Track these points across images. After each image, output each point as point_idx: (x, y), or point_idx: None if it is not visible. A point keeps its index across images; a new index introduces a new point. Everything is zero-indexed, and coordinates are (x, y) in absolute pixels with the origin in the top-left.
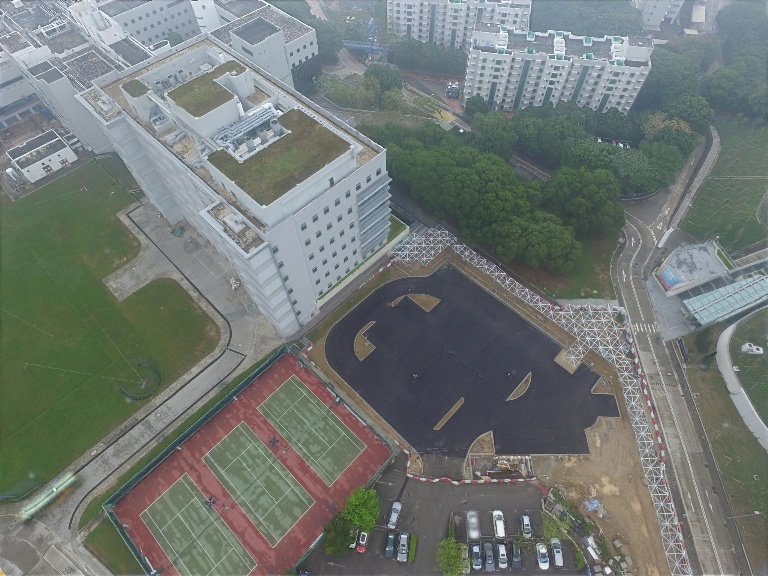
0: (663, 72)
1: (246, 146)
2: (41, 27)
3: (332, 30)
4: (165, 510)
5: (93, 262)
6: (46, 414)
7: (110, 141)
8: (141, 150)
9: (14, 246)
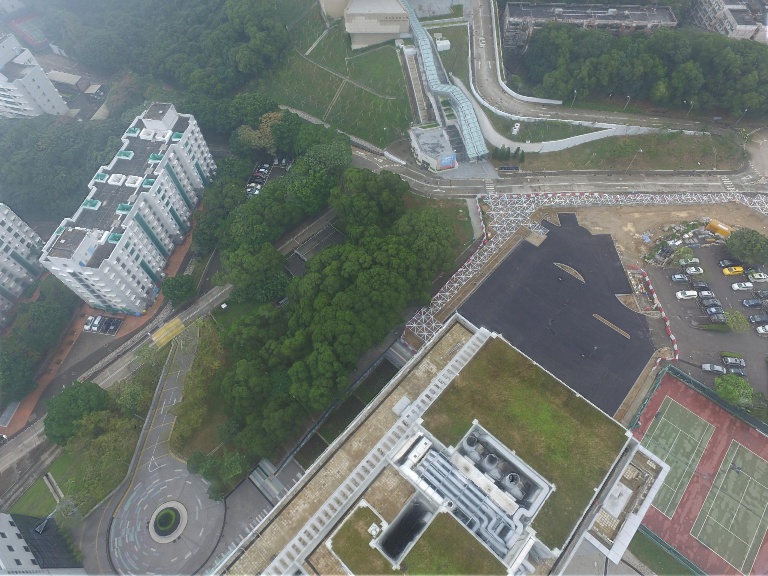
0: None
1: None
2: None
3: None
4: None
5: None
6: None
7: None
8: None
9: None
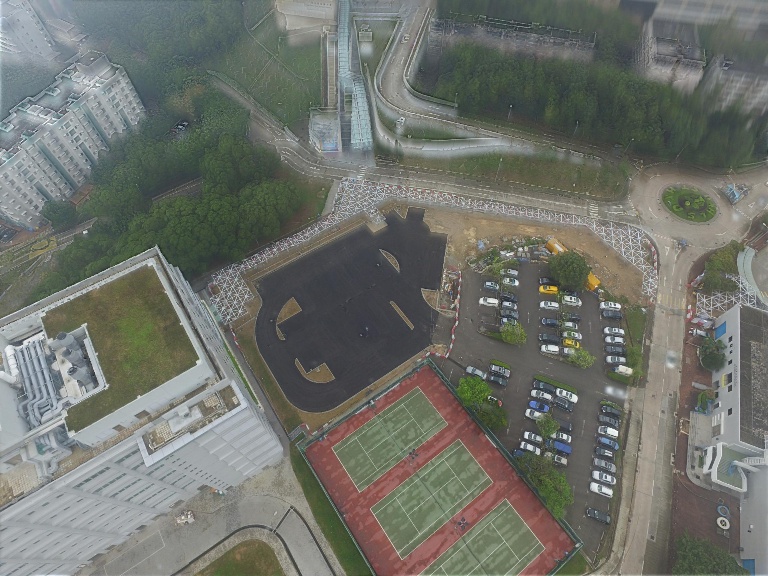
0: None
1: (79, 379)
2: None
3: None
4: None
5: None
6: None
7: None
8: None
9: None
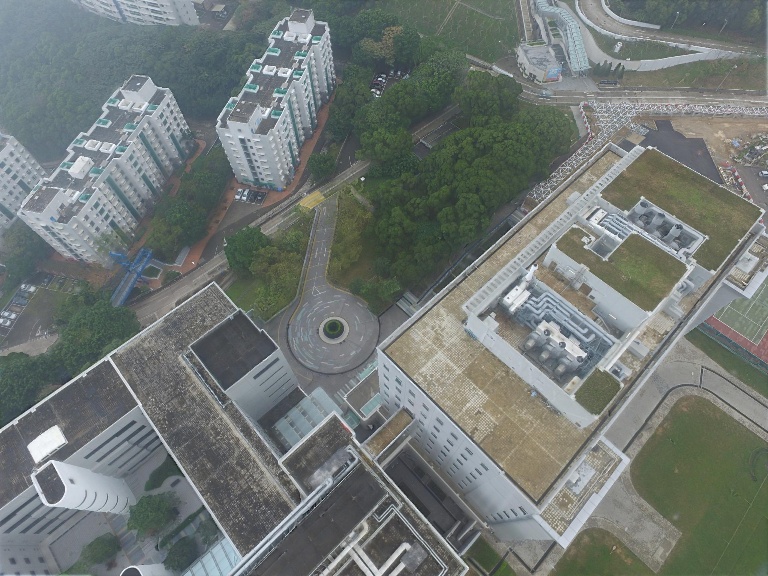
0: None
1: None
2: None
3: (104, 311)
4: None
5: None
6: None
7: None
8: None
9: None
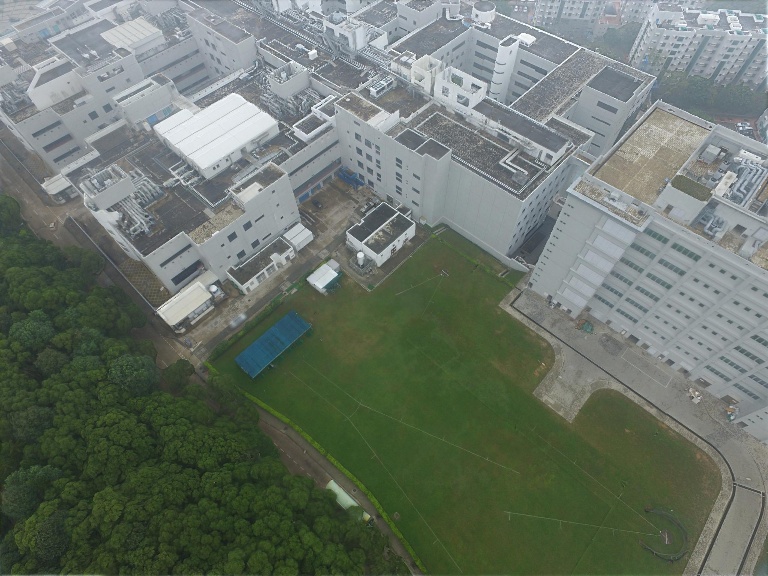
0: None
1: None
2: (362, 84)
3: None
4: None
5: (509, 370)
6: None
7: (554, 233)
8: None
9: (404, 351)
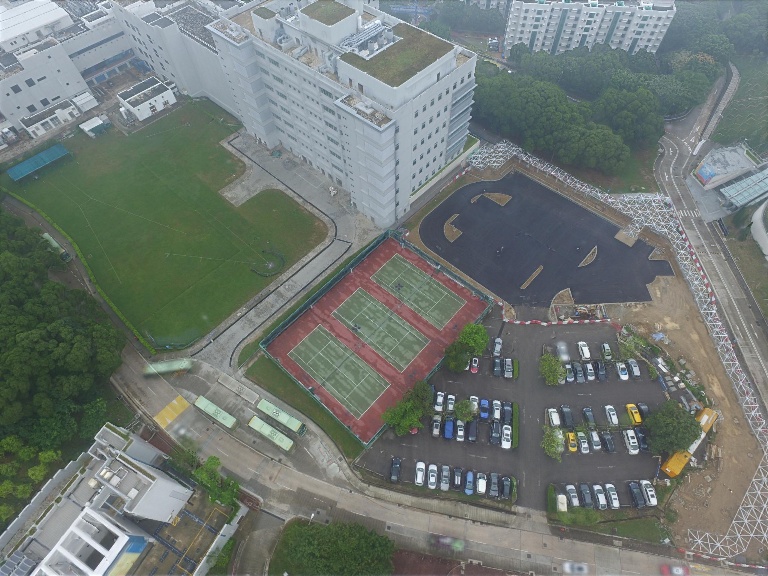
0: (684, 19)
1: (368, 49)
2: None
3: None
4: (308, 350)
5: (207, 179)
6: (193, 289)
7: (225, 71)
8: (258, 73)
9: (136, 169)
